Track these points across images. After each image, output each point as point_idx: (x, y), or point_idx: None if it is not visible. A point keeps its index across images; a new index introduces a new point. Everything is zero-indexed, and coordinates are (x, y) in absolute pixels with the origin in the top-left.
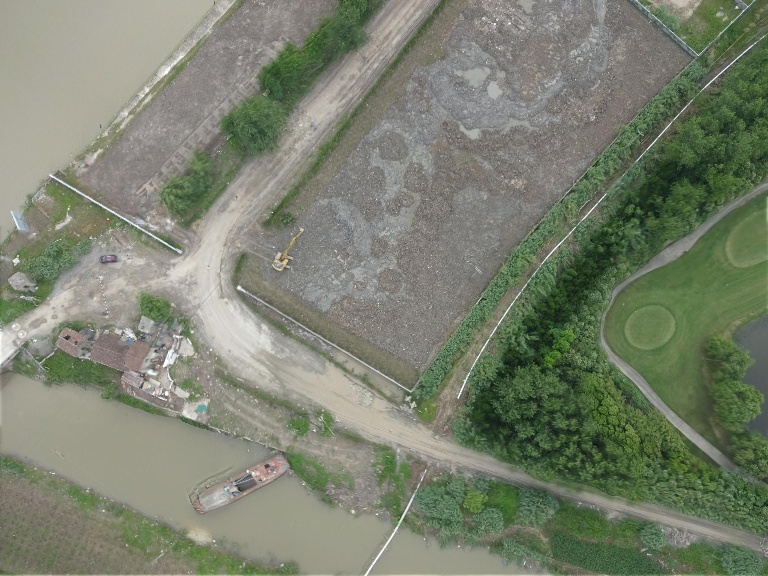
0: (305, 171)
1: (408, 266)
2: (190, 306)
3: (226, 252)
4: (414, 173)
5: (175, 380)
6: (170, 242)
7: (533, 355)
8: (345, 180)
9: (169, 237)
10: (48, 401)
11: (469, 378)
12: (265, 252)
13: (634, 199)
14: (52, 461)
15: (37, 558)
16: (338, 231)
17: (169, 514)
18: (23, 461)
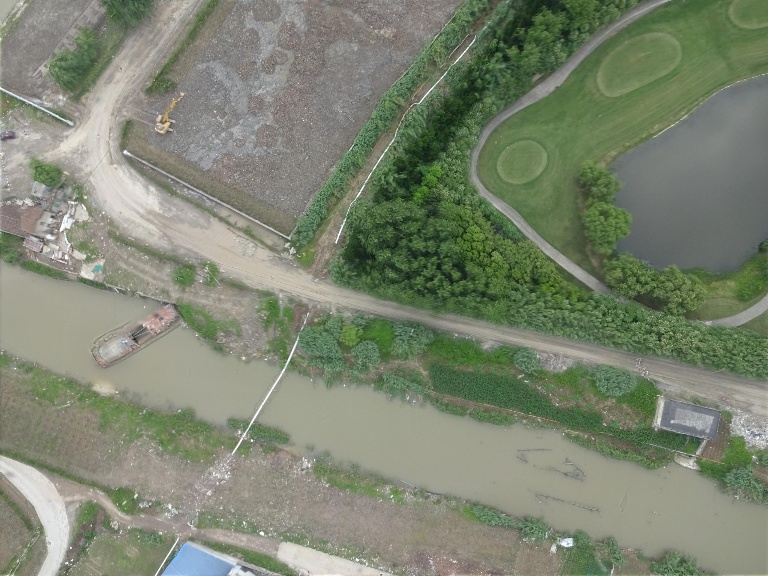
0: (183, 38)
1: (283, 120)
2: (83, 174)
3: (114, 121)
4: (286, 31)
5: (72, 243)
6: (61, 115)
7: (402, 192)
8: (221, 44)
9: (61, 111)
10: None
11: (345, 222)
12: (149, 118)
13: (499, 35)
14: None
15: None
16: (216, 92)
17: (75, 370)
18: None
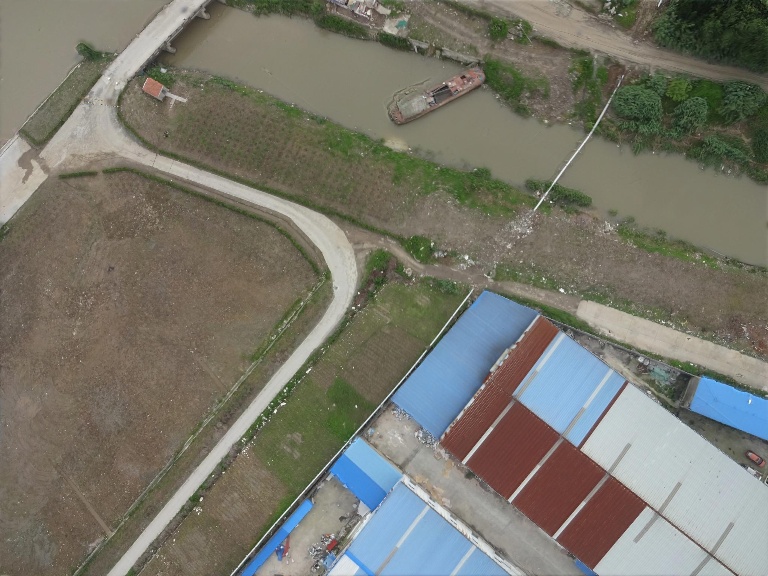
0: None
1: None
2: None
3: None
4: None
5: None
6: None
7: None
8: None
9: None
10: (257, 28)
11: None
12: None
13: None
14: (261, 80)
15: (248, 159)
16: None
17: (368, 125)
18: (234, 81)
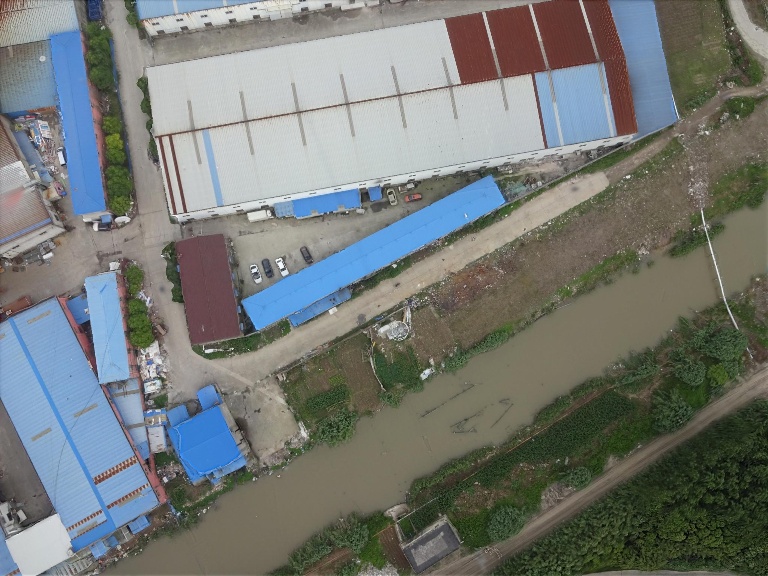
0: None
1: None
2: None
3: None
4: None
5: None
6: None
7: None
8: None
9: None
10: None
11: None
12: None
13: None
14: None
15: None
16: None
17: None
18: None
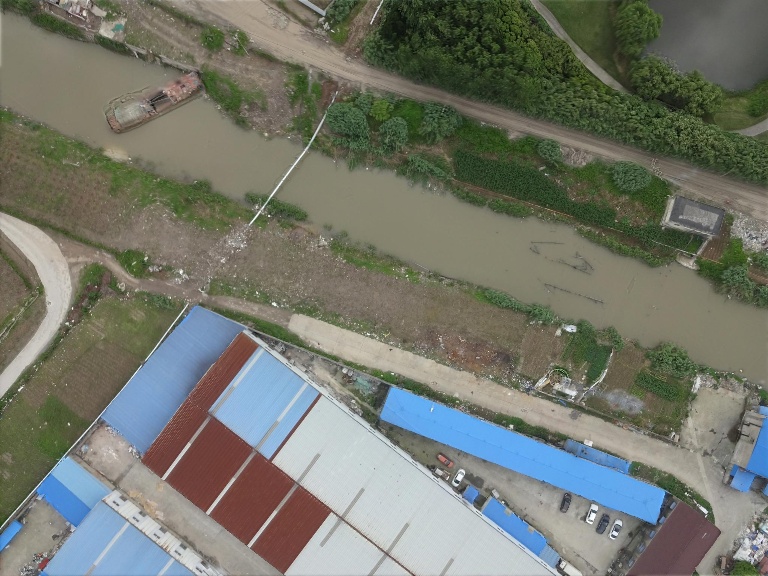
0: None
1: None
2: None
3: None
4: None
5: None
6: None
7: None
8: None
9: None
10: None
11: (382, 3)
12: None
13: None
14: None
15: None
16: None
17: (86, 132)
18: None
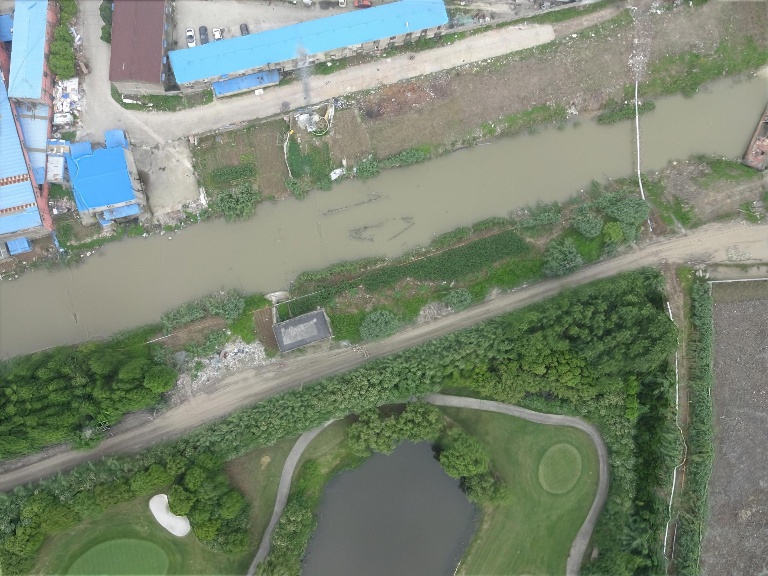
0: None
1: None
2: None
3: None
4: None
5: None
6: None
7: None
8: None
9: None
10: None
11: None
12: None
13: (653, 571)
14: None
15: None
16: None
17: None
18: None
